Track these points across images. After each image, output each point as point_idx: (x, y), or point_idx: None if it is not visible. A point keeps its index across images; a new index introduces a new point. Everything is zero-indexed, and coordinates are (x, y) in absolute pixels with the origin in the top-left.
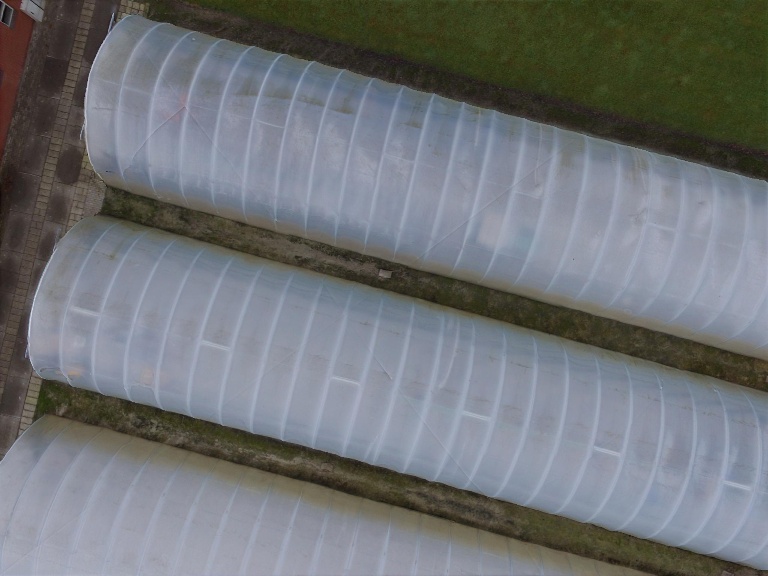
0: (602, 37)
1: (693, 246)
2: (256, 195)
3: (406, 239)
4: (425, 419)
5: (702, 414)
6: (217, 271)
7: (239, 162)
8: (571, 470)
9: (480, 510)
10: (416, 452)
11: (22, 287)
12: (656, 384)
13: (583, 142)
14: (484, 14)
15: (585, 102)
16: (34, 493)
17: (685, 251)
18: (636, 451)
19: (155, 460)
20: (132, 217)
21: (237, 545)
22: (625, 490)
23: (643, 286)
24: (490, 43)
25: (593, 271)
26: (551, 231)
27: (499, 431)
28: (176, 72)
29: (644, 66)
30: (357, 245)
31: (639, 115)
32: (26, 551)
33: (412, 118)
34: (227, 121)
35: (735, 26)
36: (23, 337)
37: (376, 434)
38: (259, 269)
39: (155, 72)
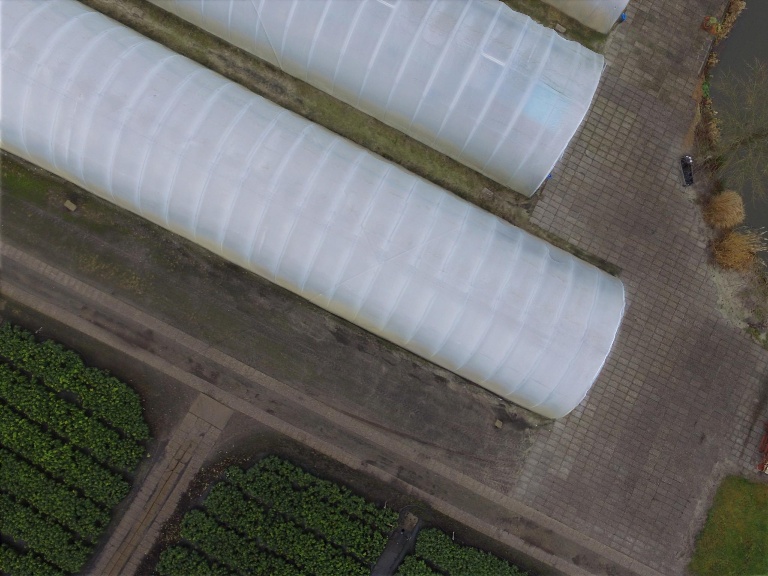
0: None
1: None
2: None
3: None
4: None
5: (479, 1)
6: None
7: None
8: (348, 11)
9: (274, 84)
10: None
11: None
12: None
13: None
14: None
15: None
16: None
17: None
18: (409, 6)
19: None
20: None
21: (19, 10)
22: (393, 41)
23: None
24: None
25: None
26: None
27: None
28: None
29: None
30: None
31: None
32: None
33: None
34: None
35: None
36: None
37: None
38: None
39: None
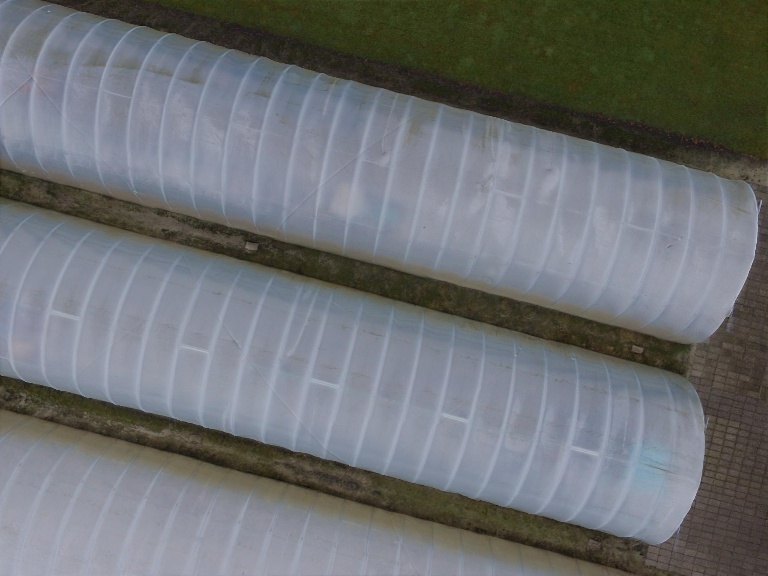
0: (467, 8)
1: (540, 213)
2: (112, 167)
3: (261, 209)
4: (274, 387)
5: (554, 381)
6: None
7: (90, 133)
8: (420, 437)
9: (348, 481)
10: (268, 420)
11: None
12: (511, 352)
13: (436, 111)
14: None
15: (451, 73)
16: None
17: (532, 218)
18: (484, 417)
19: (18, 432)
20: None
21: (90, 513)
22: (474, 456)
23: (495, 254)
24: (355, 15)
25: (444, 239)
26: (399, 199)
27: (347, 398)
28: (24, 43)
29: (509, 36)
30: (220, 217)
31: (505, 86)
32: None
33: (261, 87)
34: (74, 91)
35: None
36: None
37: (228, 403)
38: (118, 241)
39: (2, 43)
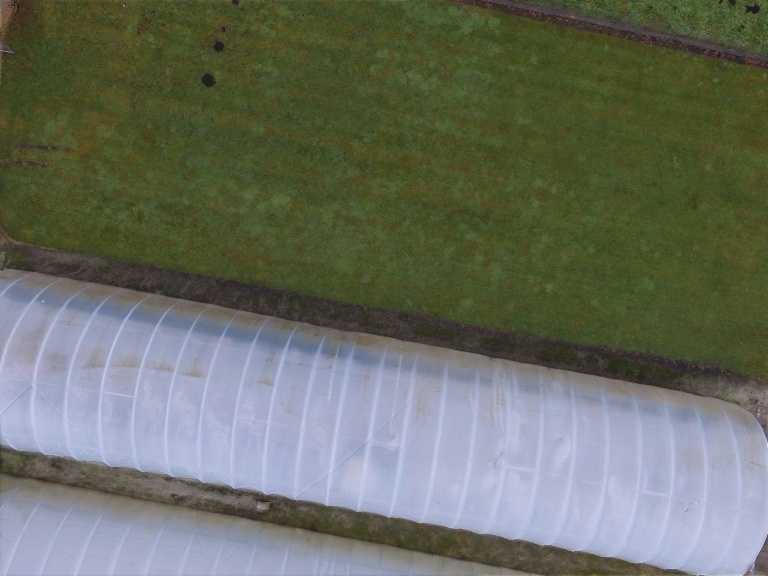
0: (464, 249)
1: (554, 486)
2: (118, 454)
3: (272, 488)
4: None
5: None
6: (86, 530)
7: (93, 431)
8: None
9: None
10: None
11: None
12: None
13: (442, 378)
14: (344, 235)
15: (452, 316)
16: None
17: (547, 491)
18: None
19: None
20: (4, 468)
21: None
22: None
23: (511, 522)
24: (352, 264)
25: (459, 512)
26: (411, 480)
27: None
28: (21, 349)
29: (508, 276)
30: None
31: (507, 325)
32: None
33: (264, 374)
34: (75, 396)
35: (596, 229)
36: None
37: None
38: (128, 525)
39: None
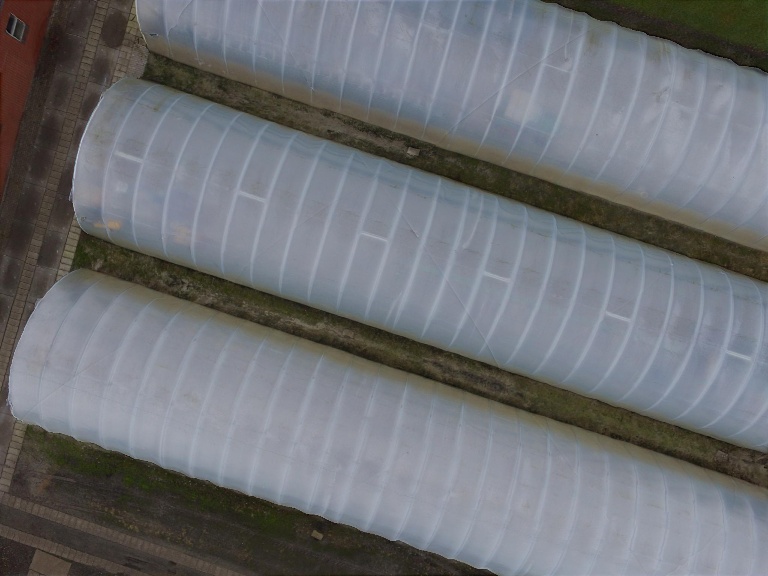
0: None
1: (712, 126)
2: (296, 61)
3: (437, 110)
4: (448, 277)
5: (709, 289)
6: (254, 134)
7: (282, 24)
8: (583, 333)
9: (492, 382)
10: (437, 310)
11: (64, 145)
12: (667, 261)
13: (612, 25)
14: None
15: None
16: (73, 328)
17: (704, 130)
18: (645, 317)
19: (186, 313)
20: (173, 83)
21: (263, 388)
22: (633, 354)
23: (661, 165)
24: None
25: (615, 148)
26: (577, 105)
27: (517, 292)
28: None
29: None
30: (388, 120)
31: (666, 12)
32: (63, 381)
33: None
34: None
35: None
36: (63, 193)
37: (400, 291)
38: (295, 134)
39: None
